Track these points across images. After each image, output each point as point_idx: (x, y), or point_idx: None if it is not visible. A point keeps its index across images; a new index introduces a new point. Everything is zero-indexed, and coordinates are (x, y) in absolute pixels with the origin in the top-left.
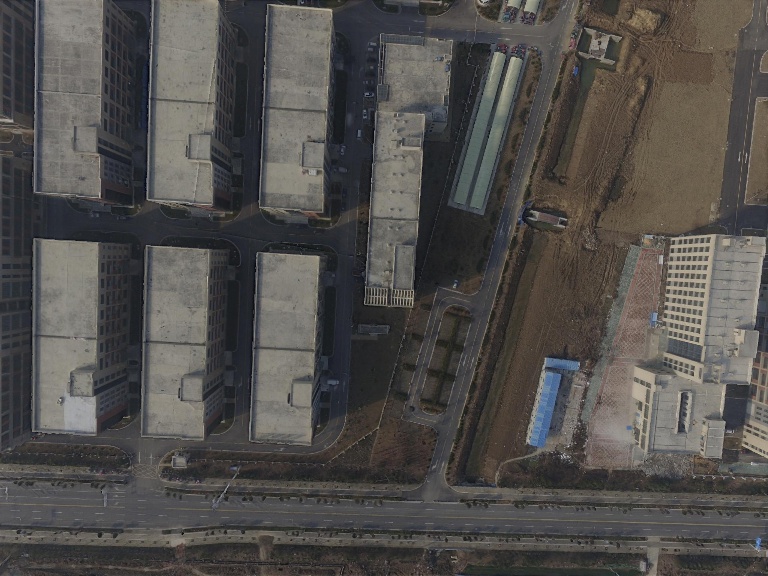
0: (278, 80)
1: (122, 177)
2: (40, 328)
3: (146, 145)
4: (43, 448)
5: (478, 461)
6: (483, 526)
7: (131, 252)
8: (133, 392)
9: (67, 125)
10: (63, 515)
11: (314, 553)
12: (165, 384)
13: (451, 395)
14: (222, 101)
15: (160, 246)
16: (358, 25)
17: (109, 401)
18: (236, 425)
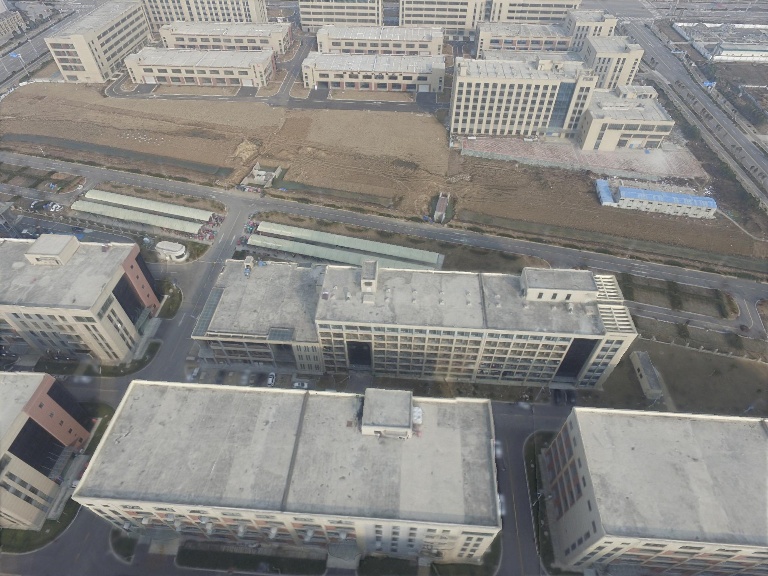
0: (231, 482)
1: None
2: None
3: None
4: None
5: (766, 264)
6: None
7: None
8: None
9: None
10: None
11: None
12: None
13: (696, 285)
14: None
15: None
16: None
17: None
18: None
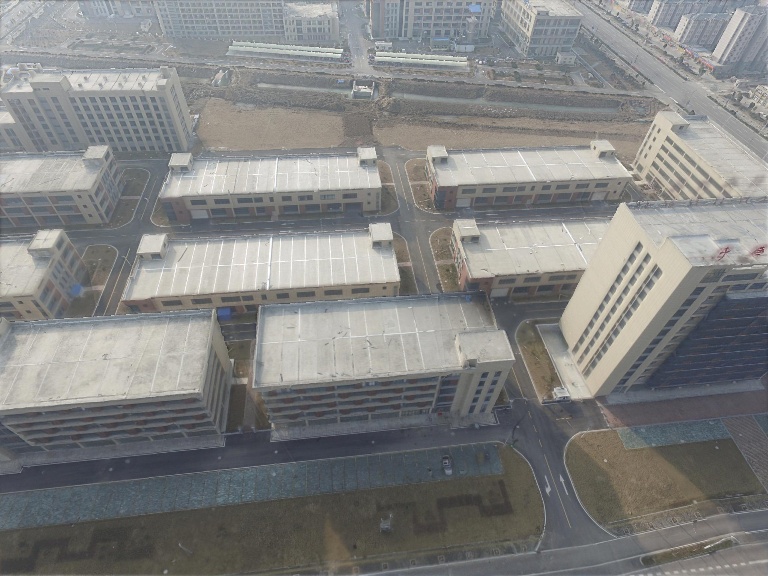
0: None
1: None
2: None
3: None
4: None
5: None
6: None
7: None
8: None
9: None
10: None
11: None
12: None
13: None
14: None
15: None
16: None
17: None
18: None
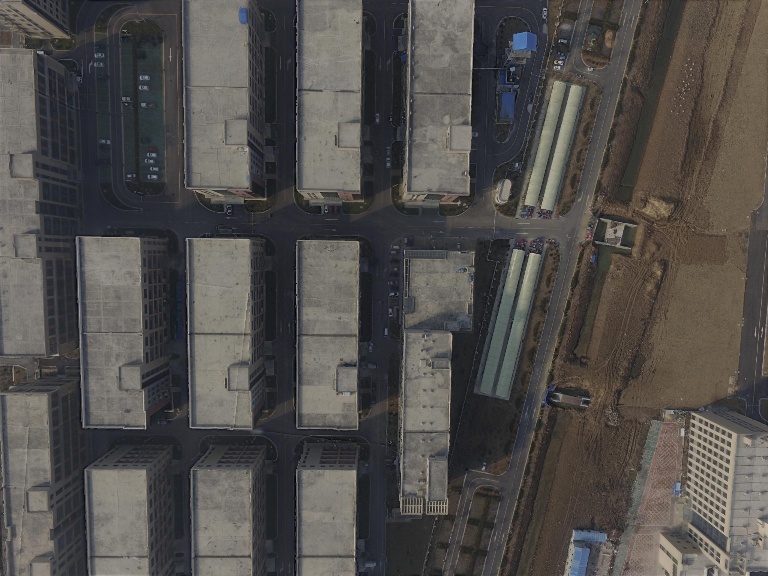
0: (310, 309)
1: (162, 391)
2: (94, 550)
3: (182, 353)
4: None
5: None
6: None
7: (172, 453)
8: None
9: (111, 362)
10: None
11: None
12: None
13: (484, 569)
14: (255, 322)
15: (204, 469)
16: (381, 229)
17: None
18: None
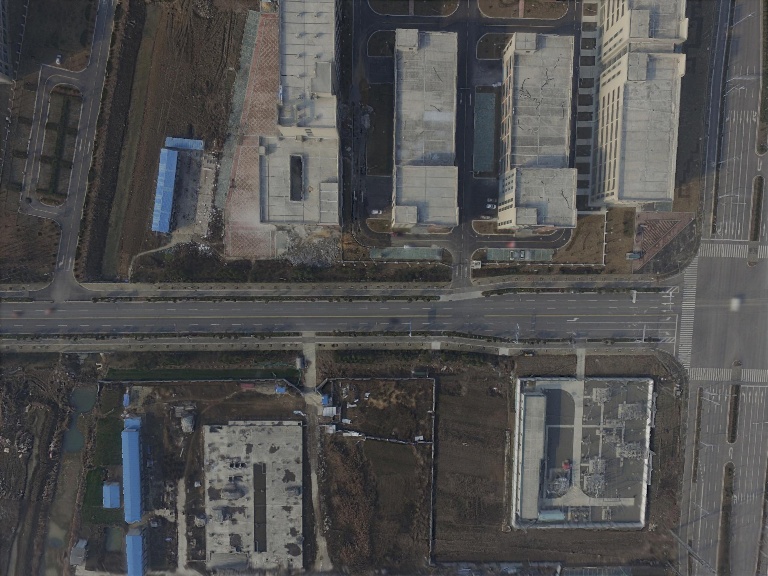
0: None
1: None
2: None
3: None
4: None
5: (114, 259)
6: (121, 326)
7: None
8: None
9: None
10: None
11: None
12: None
13: (70, 184)
14: None
15: None
16: None
17: None
18: None
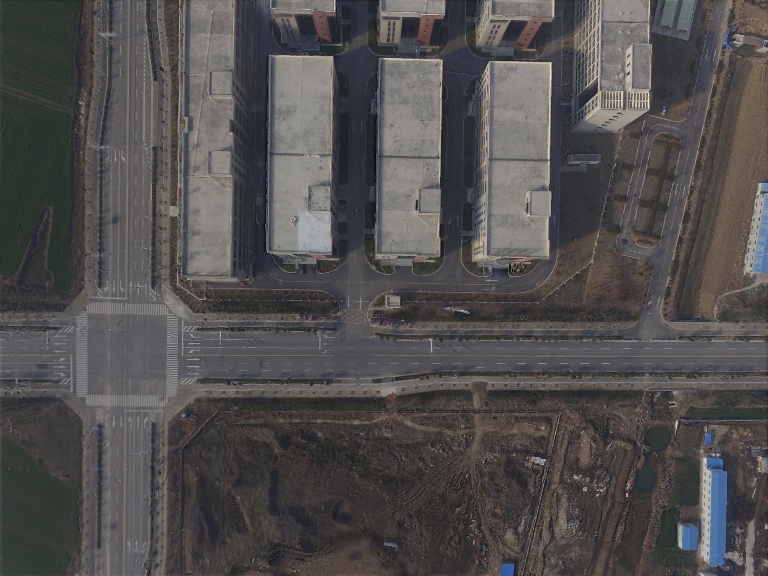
0: None
1: (338, 8)
2: (274, 146)
3: None
4: (252, 294)
5: (692, 298)
6: (704, 365)
7: (339, 90)
8: (342, 233)
9: None
10: (271, 366)
11: (530, 399)
12: (399, 200)
13: (664, 226)
14: None
15: (393, 58)
16: None
17: (333, 229)
18: (446, 265)
